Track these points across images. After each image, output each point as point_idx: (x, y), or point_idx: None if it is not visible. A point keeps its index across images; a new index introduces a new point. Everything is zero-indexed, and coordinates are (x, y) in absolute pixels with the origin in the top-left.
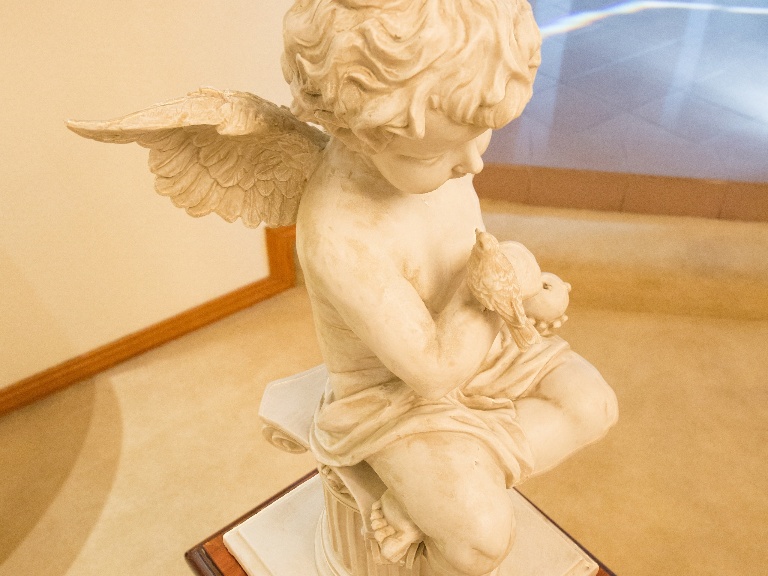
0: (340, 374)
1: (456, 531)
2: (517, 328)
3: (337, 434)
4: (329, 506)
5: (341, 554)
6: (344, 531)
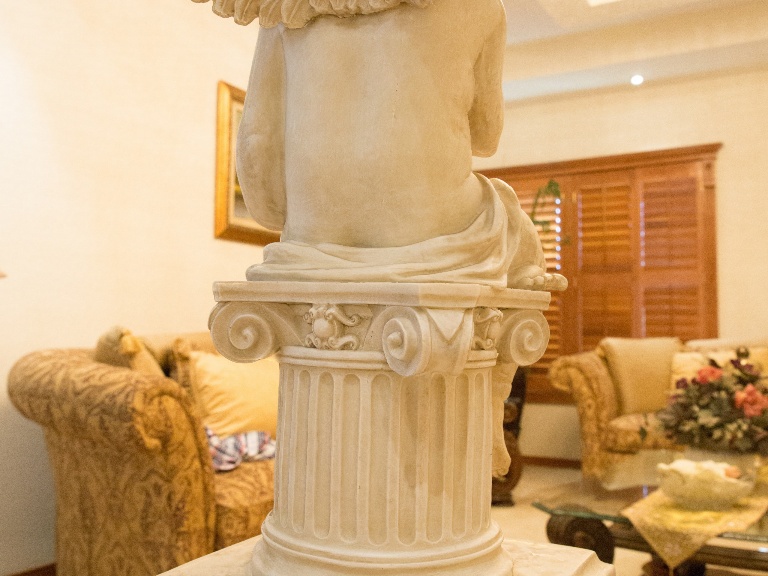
0: (471, 173)
1: None
2: None
3: (489, 247)
4: None
5: None
6: None
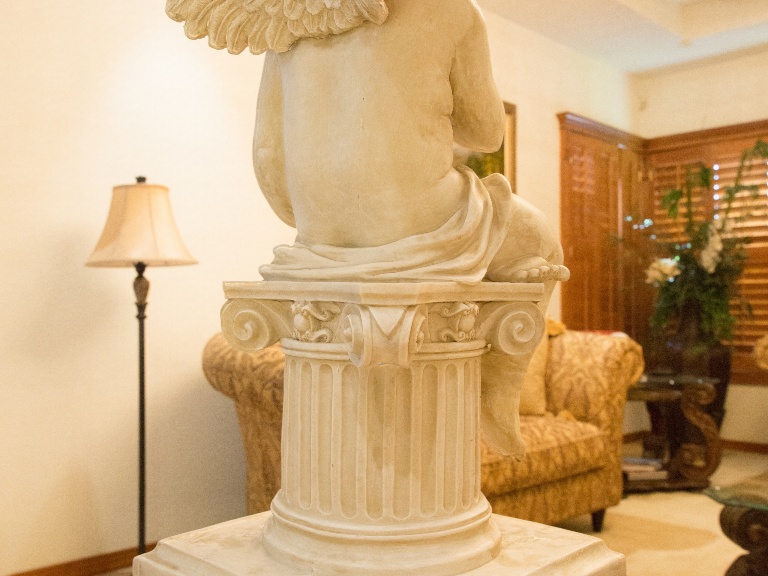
0: (449, 173)
1: None
2: None
3: (467, 244)
4: (446, 409)
5: (462, 481)
6: None
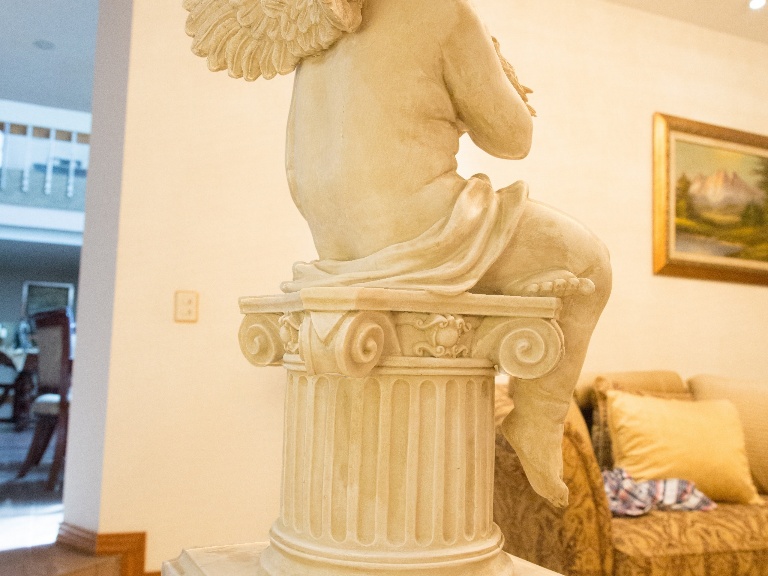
0: (438, 179)
1: (599, 243)
2: (524, 102)
3: (454, 253)
4: (420, 429)
5: (441, 512)
6: (446, 451)
